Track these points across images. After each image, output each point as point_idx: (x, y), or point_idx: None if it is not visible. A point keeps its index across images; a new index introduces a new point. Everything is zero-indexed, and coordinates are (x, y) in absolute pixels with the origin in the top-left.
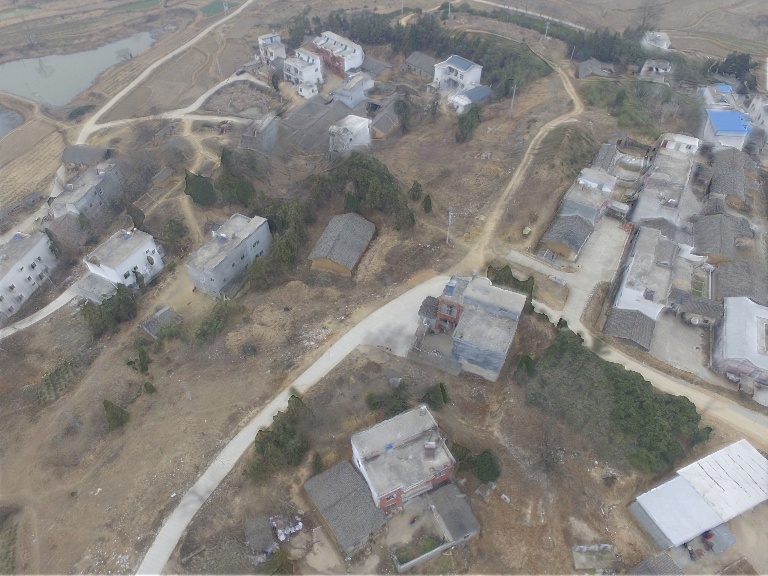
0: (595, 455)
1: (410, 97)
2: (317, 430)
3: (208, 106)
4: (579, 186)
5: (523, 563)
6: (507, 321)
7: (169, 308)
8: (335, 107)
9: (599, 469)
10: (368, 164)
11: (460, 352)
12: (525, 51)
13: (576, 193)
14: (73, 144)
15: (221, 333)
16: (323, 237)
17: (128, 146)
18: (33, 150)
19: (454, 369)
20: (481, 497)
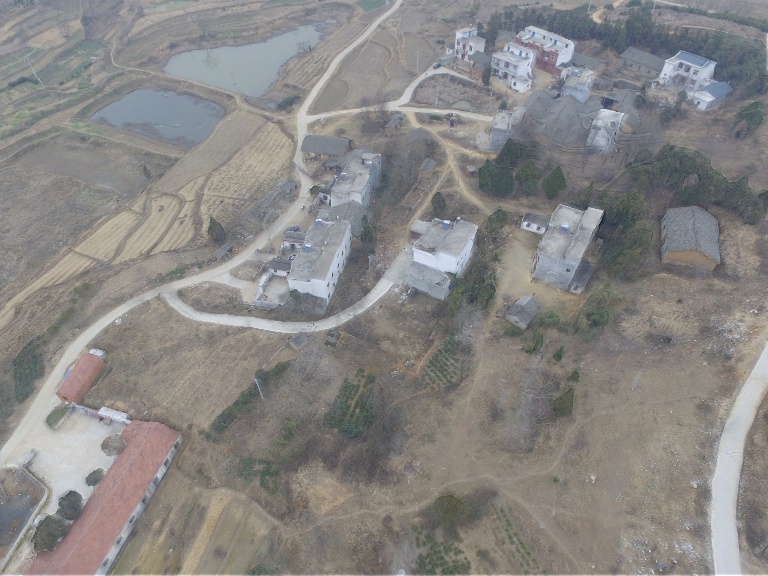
0: None
1: (644, 92)
2: None
3: (417, 99)
4: None
5: None
6: None
7: (531, 298)
8: (569, 101)
9: None
10: (695, 157)
11: None
12: (763, 47)
13: None
14: (295, 134)
15: (606, 324)
16: (672, 230)
17: (356, 137)
18: (255, 140)
19: None
20: None
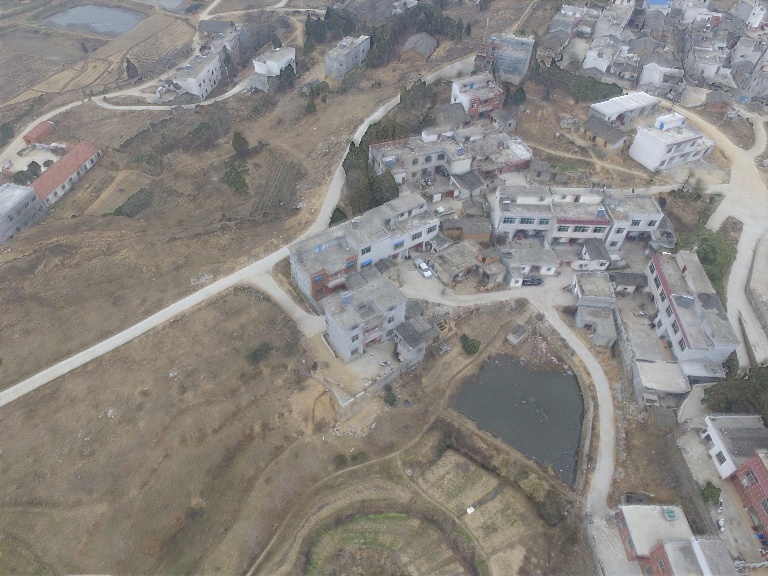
0: (570, 98)
1: None
2: (429, 98)
3: (290, 5)
4: (562, 14)
5: (537, 132)
6: (525, 52)
7: (317, 79)
8: None
9: (572, 102)
10: None
11: (501, 66)
12: None
13: (560, 18)
14: (197, 25)
15: (354, 86)
16: (407, 44)
17: None
18: (167, 29)
19: (497, 78)
20: (515, 115)
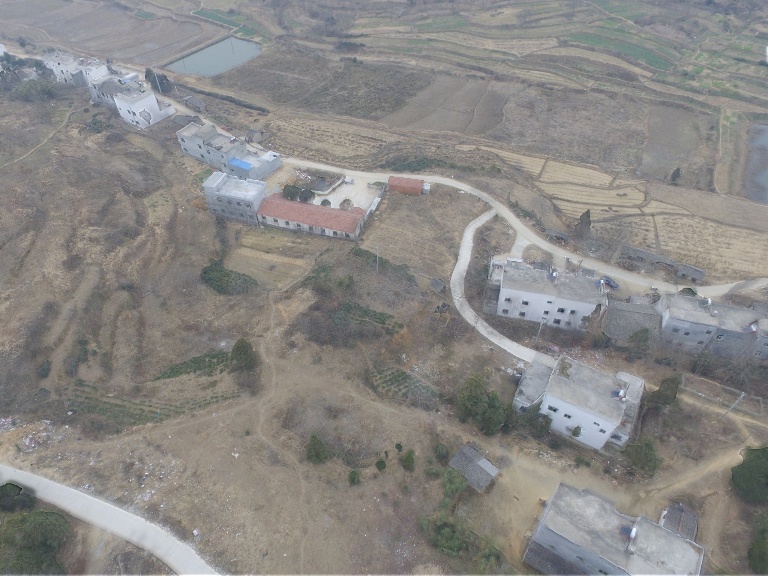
0: None
1: None
2: None
3: None
4: None
5: None
6: None
7: (490, 474)
8: None
9: None
10: None
11: None
12: None
13: None
14: None
15: (445, 555)
16: None
17: None
18: None
19: None
20: None
